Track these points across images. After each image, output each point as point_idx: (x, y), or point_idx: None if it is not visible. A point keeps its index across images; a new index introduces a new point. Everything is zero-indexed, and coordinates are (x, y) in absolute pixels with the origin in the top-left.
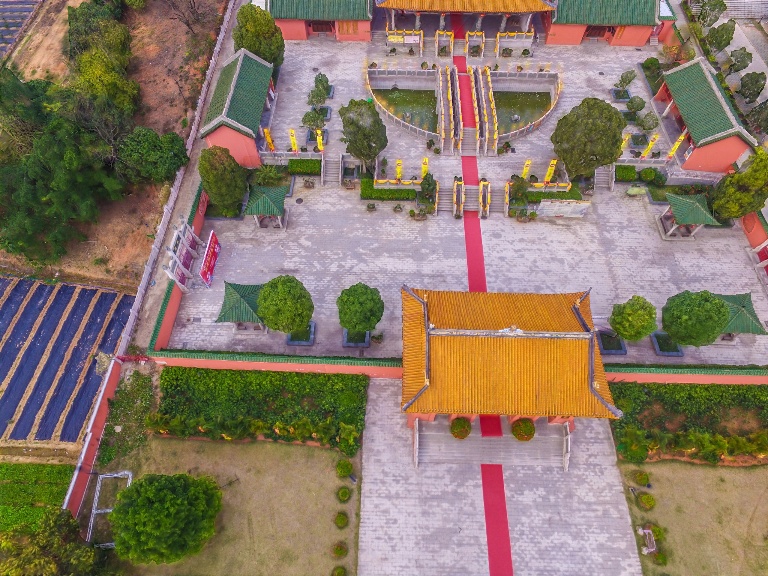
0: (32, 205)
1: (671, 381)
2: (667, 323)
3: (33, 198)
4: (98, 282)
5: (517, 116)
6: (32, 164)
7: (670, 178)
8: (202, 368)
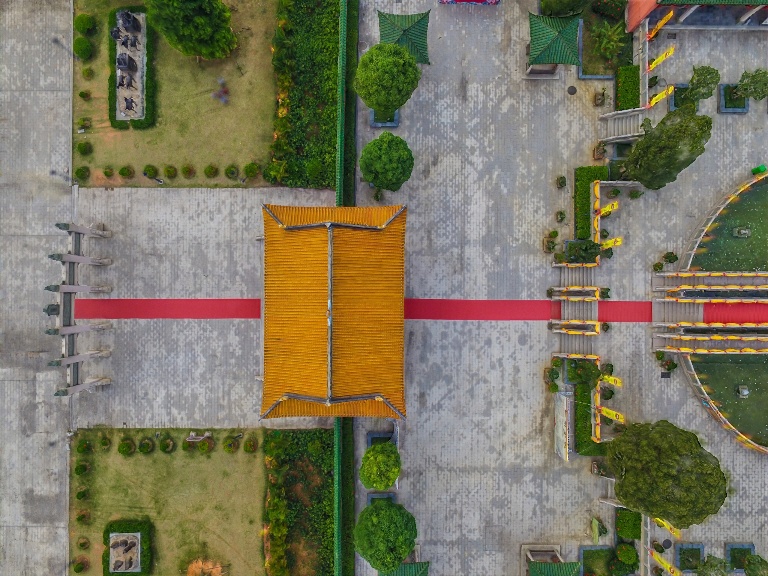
0: None
1: None
2: (377, 502)
3: None
4: None
5: (745, 393)
6: None
7: None
8: None
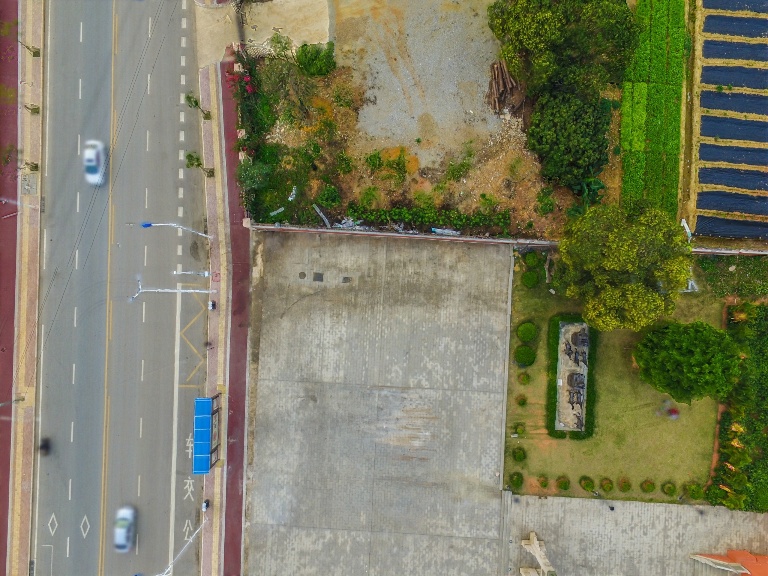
0: None
1: None
2: None
3: None
4: None
5: None
6: None
7: None
8: None
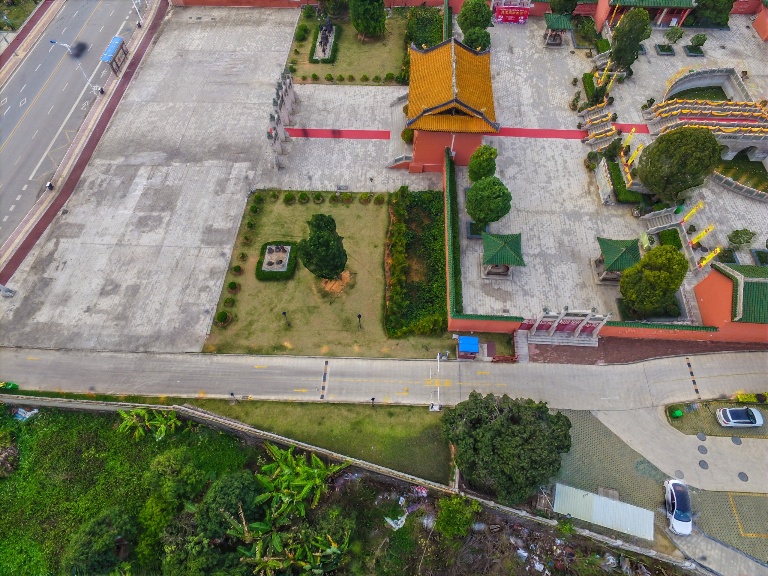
0: None
1: None
2: None
3: None
4: None
5: (729, 178)
6: None
7: None
8: None
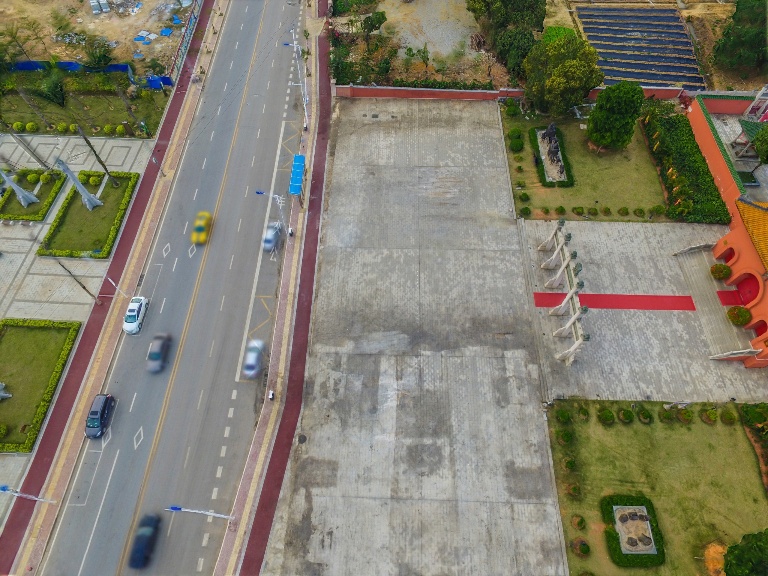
0: (766, 32)
1: None
2: None
3: None
4: None
5: None
6: None
7: None
8: (693, 132)
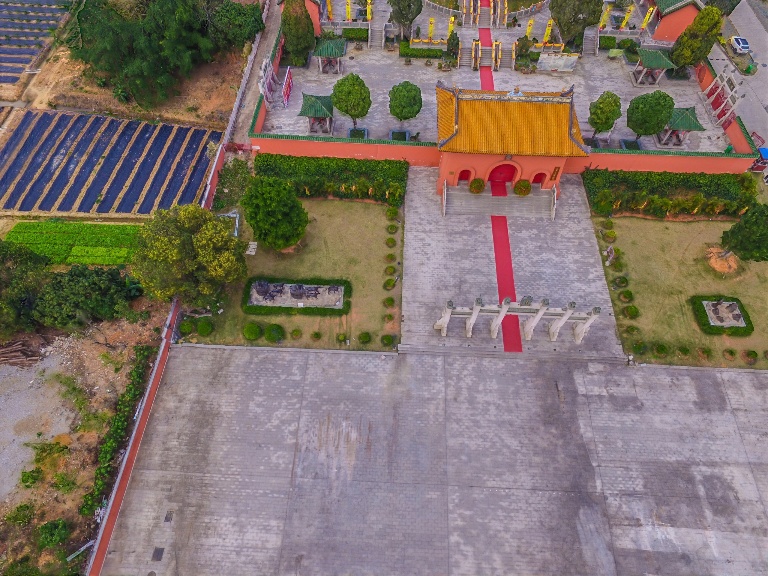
0: (146, 54)
1: (633, 169)
2: (629, 115)
3: (149, 46)
4: (190, 124)
5: (523, 7)
6: (148, 21)
7: (642, 45)
8: (285, 155)
